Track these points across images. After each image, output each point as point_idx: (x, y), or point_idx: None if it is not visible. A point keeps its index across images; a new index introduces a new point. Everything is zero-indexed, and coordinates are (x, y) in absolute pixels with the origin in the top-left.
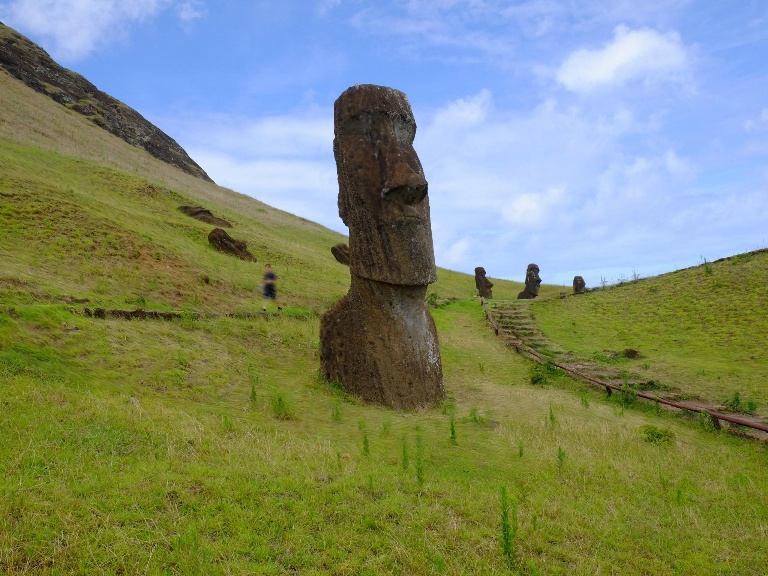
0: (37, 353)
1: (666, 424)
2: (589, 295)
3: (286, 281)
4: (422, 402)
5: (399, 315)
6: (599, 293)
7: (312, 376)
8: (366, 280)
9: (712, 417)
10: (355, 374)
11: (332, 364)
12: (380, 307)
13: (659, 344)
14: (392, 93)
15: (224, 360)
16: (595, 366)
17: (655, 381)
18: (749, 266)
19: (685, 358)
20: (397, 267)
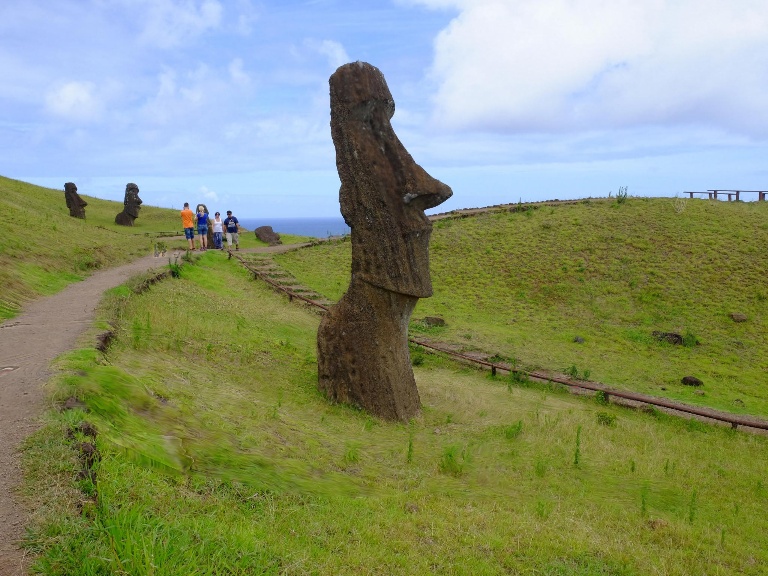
0: (230, 459)
1: (582, 403)
2: (319, 249)
3: (1, 230)
4: (416, 410)
5: (403, 325)
6: (329, 247)
7: (317, 398)
8: (386, 291)
9: (605, 394)
10: (372, 392)
11: (339, 382)
12: (393, 319)
13: (433, 307)
14: (382, 76)
15: (241, 395)
16: (428, 338)
17: (498, 354)
18: (454, 231)
19: (475, 324)
20: (419, 278)
